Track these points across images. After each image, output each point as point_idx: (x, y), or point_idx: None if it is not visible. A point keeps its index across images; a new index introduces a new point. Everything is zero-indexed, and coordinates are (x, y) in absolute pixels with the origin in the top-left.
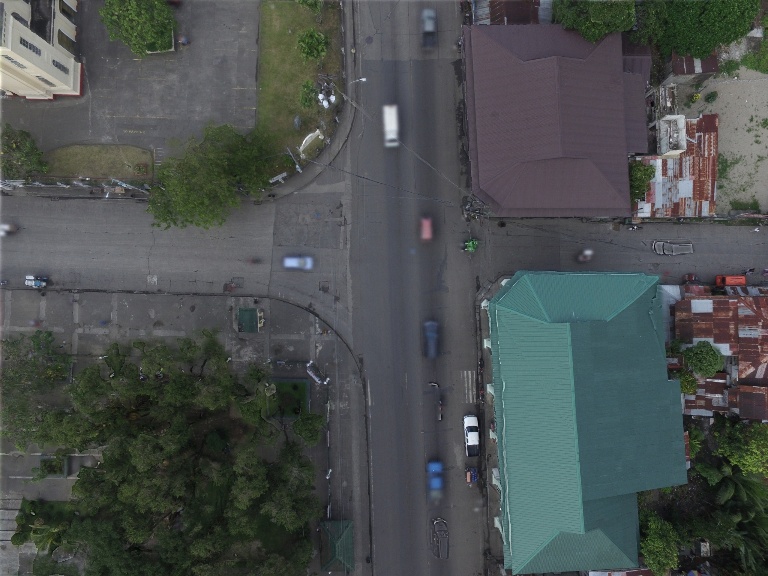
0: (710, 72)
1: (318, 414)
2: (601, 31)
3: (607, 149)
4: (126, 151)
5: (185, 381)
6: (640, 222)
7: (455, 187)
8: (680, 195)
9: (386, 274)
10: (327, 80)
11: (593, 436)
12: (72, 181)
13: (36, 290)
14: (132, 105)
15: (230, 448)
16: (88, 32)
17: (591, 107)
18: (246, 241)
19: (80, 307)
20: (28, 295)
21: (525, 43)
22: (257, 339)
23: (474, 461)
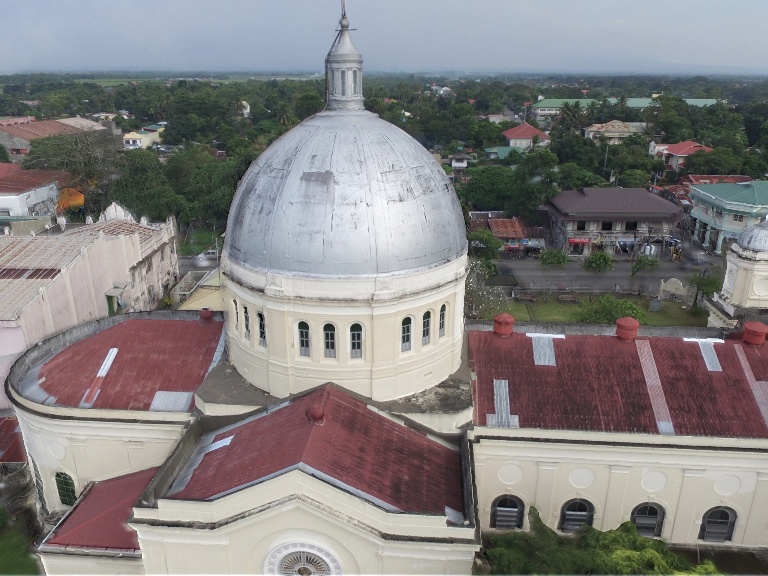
0: None
1: None
2: None
3: None
4: None
5: None
6: None
7: None
8: None
9: None
10: None
11: None
12: None
13: None
14: None
15: None
16: None
17: None
18: None
19: None
20: None
21: None
22: None
23: None
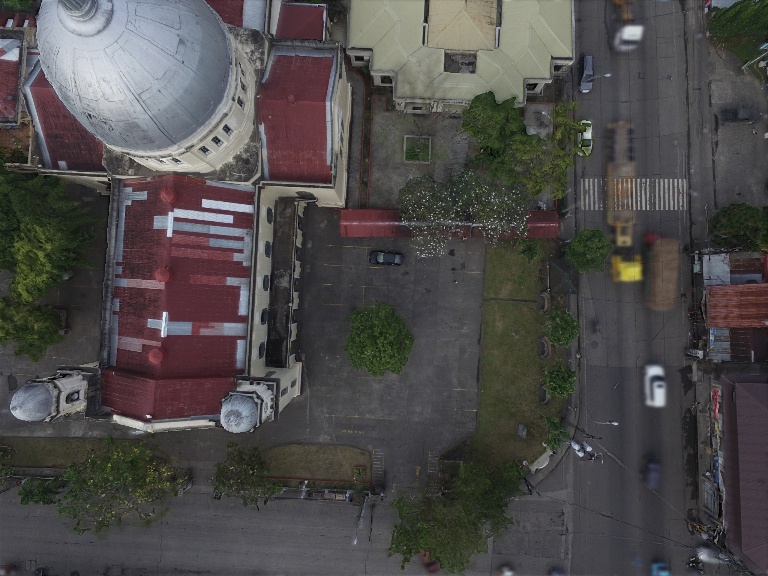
0: None
1: None
2: None
3: None
4: (344, 451)
5: None
6: None
7: (680, 499)
8: None
9: None
10: None
11: None
12: (290, 482)
13: None
14: (351, 404)
15: None
16: (308, 328)
17: None
18: None
19: None
20: None
21: None
22: None
23: None
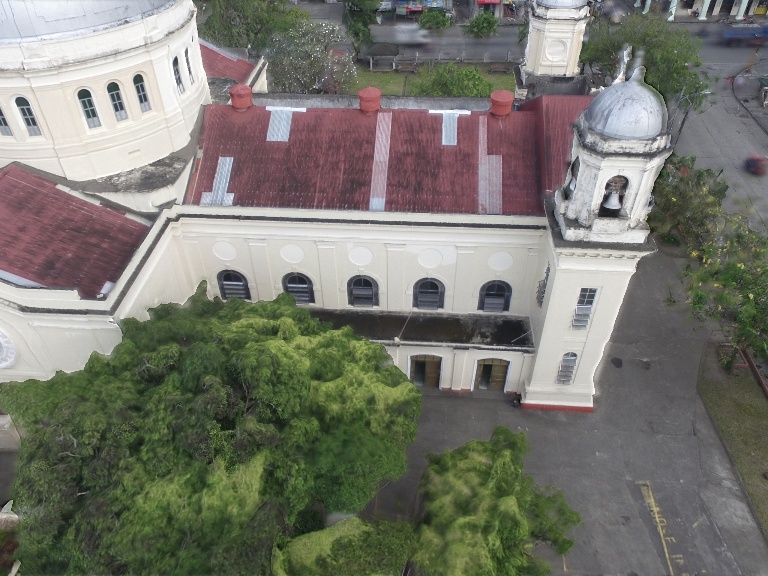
0: None
1: None
2: None
3: None
4: None
5: None
6: None
7: None
8: None
9: None
10: None
11: None
12: None
13: None
14: None
15: None
16: None
17: None
18: None
19: None
20: None
21: None
22: None
23: None
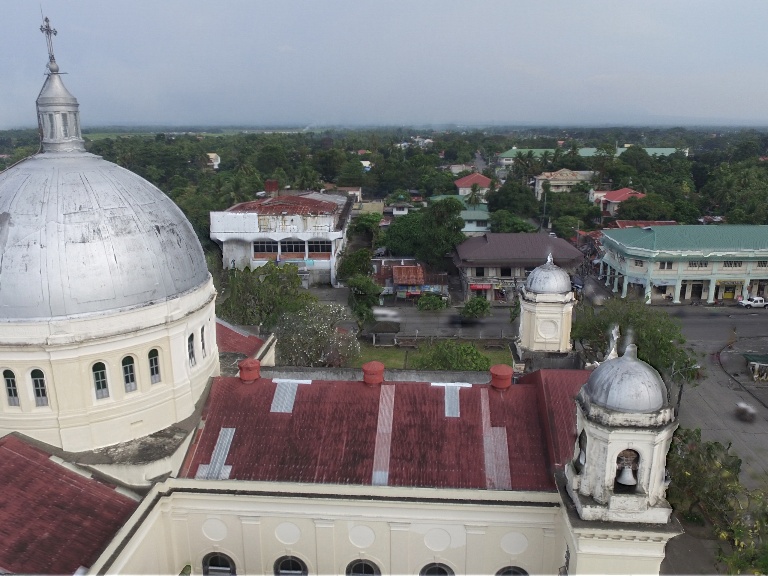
0: None
1: None
2: None
3: None
4: None
5: None
6: None
7: None
8: None
9: None
10: None
11: None
12: None
13: None
14: None
15: None
16: None
17: None
18: None
19: None
20: None
21: None
22: None
23: None
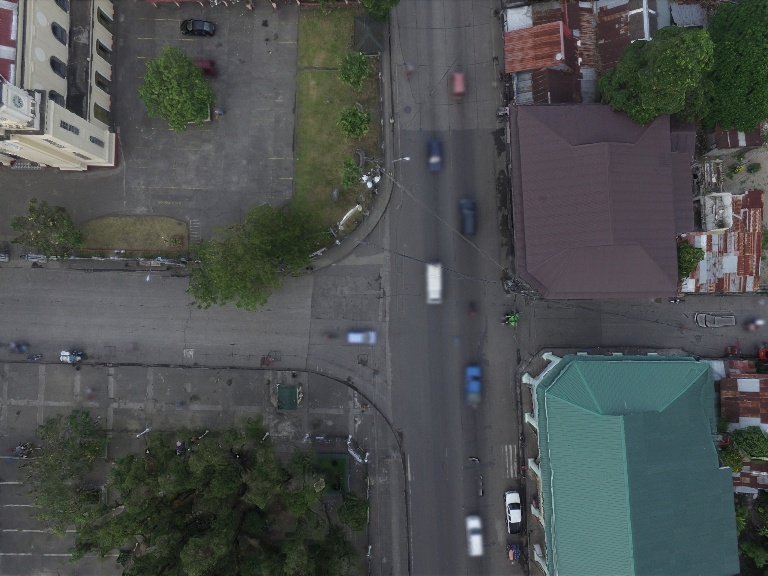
0: (754, 146)
1: (357, 489)
2: (651, 114)
3: (657, 233)
4: (161, 222)
5: (231, 473)
6: (683, 296)
7: (495, 259)
8: (724, 270)
9: (426, 347)
10: (365, 150)
11: (647, 530)
12: (107, 253)
13: (70, 364)
14: (167, 176)
15: (268, 525)
16: (122, 101)
17: (641, 191)
18: (284, 314)
19: (115, 381)
20: (62, 369)
21: (573, 126)
22: (295, 413)
23: (515, 537)
